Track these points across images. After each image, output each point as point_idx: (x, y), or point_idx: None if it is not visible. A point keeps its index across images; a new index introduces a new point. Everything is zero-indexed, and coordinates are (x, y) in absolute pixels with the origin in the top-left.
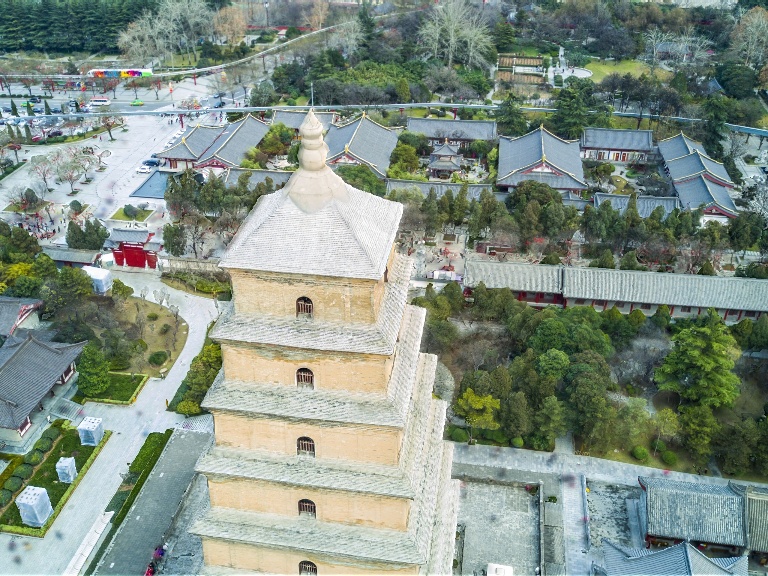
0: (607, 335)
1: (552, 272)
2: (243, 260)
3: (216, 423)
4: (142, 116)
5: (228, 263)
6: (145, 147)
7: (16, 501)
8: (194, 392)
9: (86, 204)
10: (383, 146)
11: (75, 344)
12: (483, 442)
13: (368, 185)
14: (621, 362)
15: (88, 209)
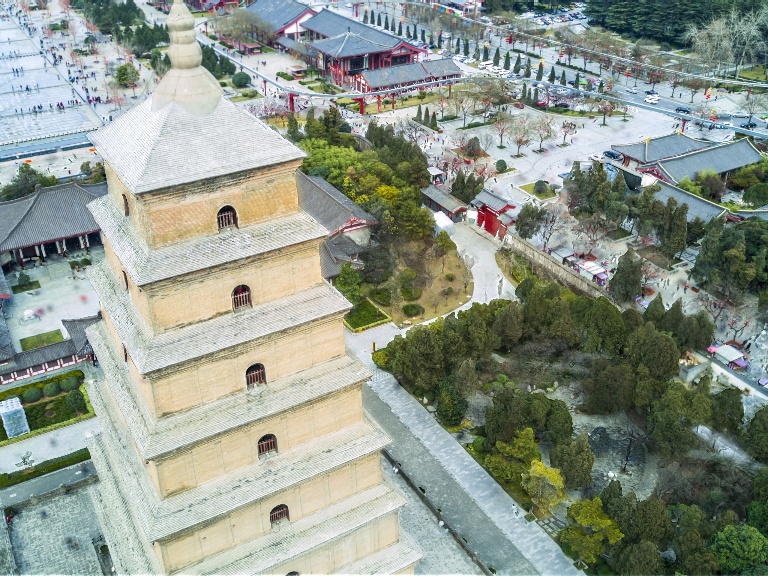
0: None
1: None
2: (98, 137)
3: None
4: (657, 113)
5: (91, 135)
6: (624, 140)
7: None
8: (389, 346)
9: (515, 168)
10: None
11: (352, 261)
12: (592, 574)
13: None
14: None
15: (512, 172)
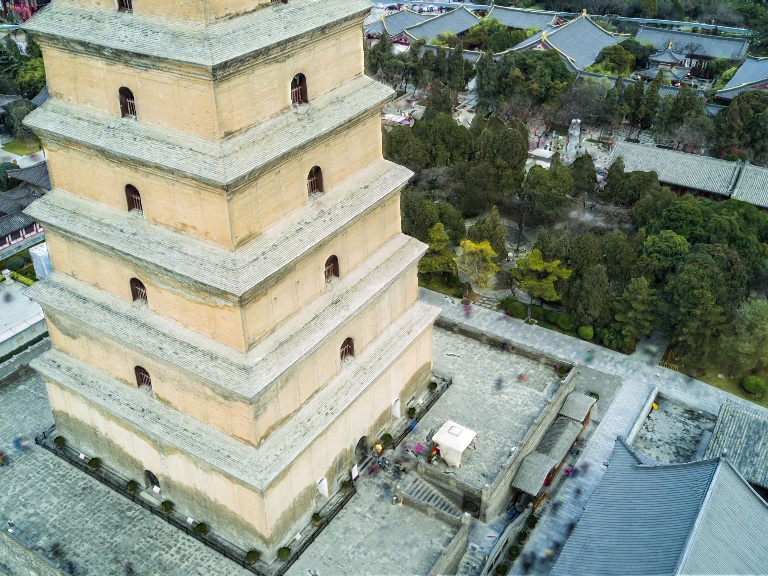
0: None
1: (725, 169)
2: None
3: (45, 62)
4: None
5: None
6: None
7: (30, 250)
8: None
9: None
10: (594, 47)
11: None
12: (544, 324)
13: (550, 70)
14: None
15: None
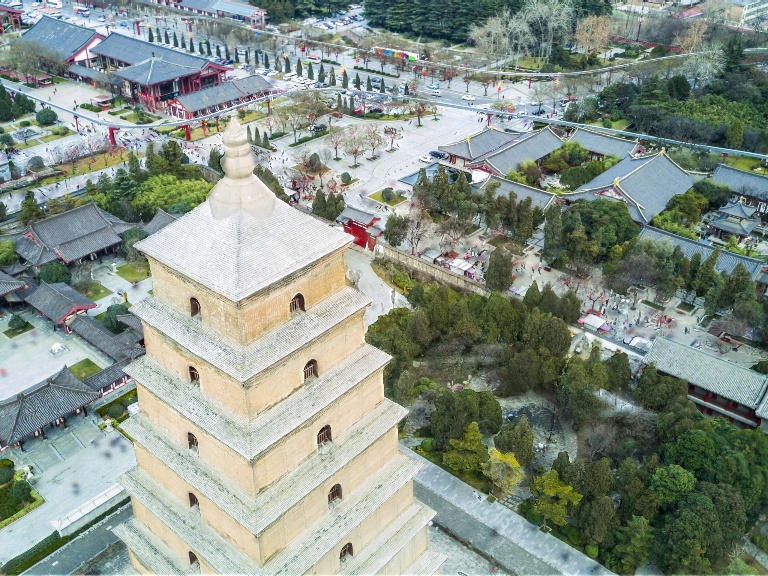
0: None
1: (755, 381)
2: (151, 247)
3: (138, 391)
4: (460, 109)
5: (140, 246)
6: (442, 138)
7: (128, 408)
8: None
9: (357, 178)
10: (668, 189)
11: None
12: (557, 534)
13: (615, 225)
14: None
15: (356, 183)
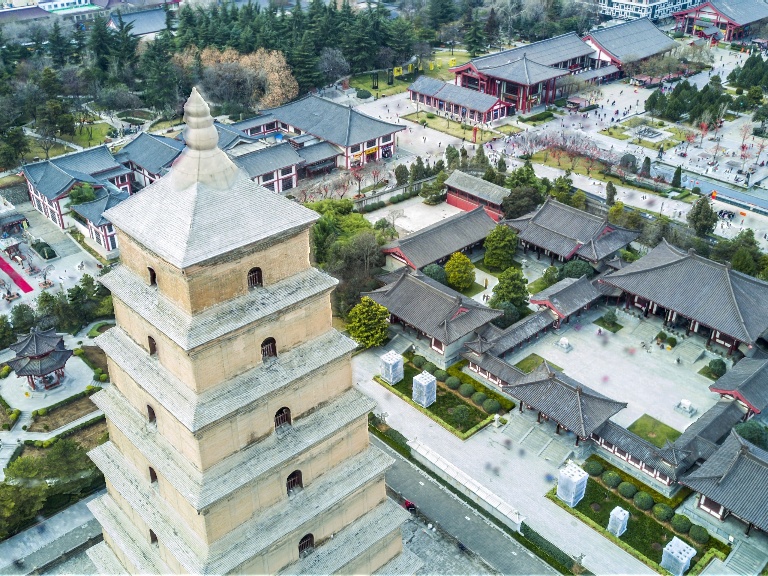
0: None
1: None
2: None
3: None
4: None
5: None
6: None
7: None
8: None
9: None
10: None
11: None
12: None
13: None
14: None
15: None
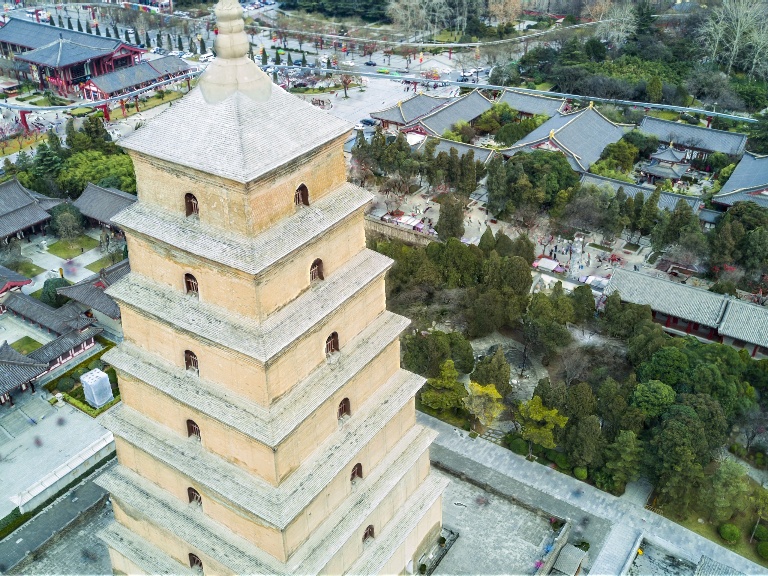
0: (752, 388)
1: (714, 301)
2: (137, 141)
3: (122, 315)
4: (385, 81)
5: (124, 142)
6: (371, 108)
7: (81, 378)
8: None
9: None
10: (600, 140)
11: None
12: (543, 461)
13: (556, 174)
14: (766, 426)
15: None
